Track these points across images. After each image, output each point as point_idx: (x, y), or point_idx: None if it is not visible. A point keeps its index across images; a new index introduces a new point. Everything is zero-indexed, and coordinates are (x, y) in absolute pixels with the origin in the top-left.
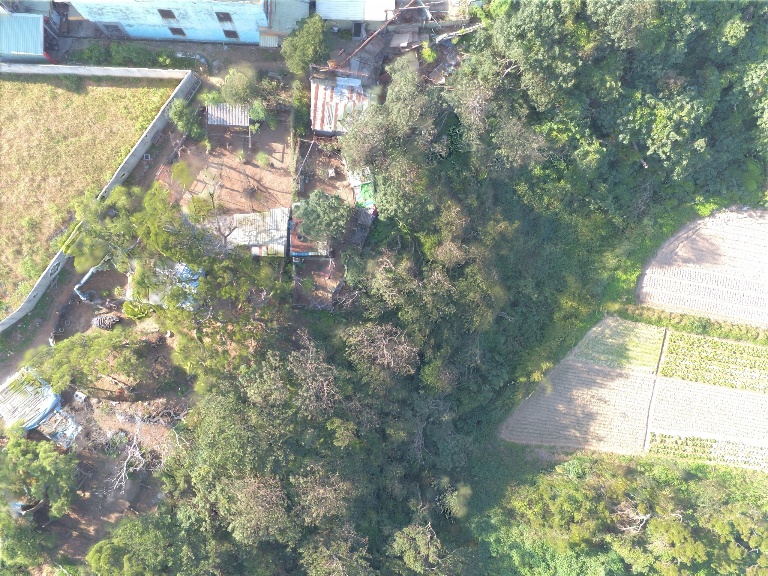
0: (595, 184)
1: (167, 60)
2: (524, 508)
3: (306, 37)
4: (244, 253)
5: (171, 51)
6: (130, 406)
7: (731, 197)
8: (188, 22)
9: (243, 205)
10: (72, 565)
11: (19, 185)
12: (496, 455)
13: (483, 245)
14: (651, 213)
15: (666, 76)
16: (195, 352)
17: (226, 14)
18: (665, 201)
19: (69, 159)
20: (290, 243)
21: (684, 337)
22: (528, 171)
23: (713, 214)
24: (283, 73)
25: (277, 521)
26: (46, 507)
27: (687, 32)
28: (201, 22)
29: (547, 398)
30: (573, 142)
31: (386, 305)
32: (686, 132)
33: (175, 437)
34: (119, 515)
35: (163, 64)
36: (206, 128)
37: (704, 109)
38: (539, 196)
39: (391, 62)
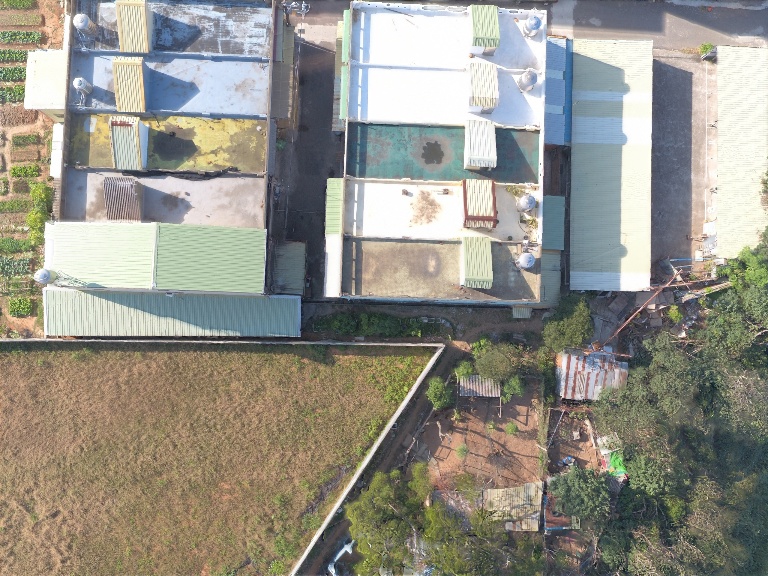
0: None
1: (420, 333)
2: None
3: (575, 325)
4: (499, 530)
5: (416, 316)
6: None
7: None
8: None
9: (488, 470)
10: None
11: (269, 460)
12: None
13: (726, 504)
14: None
15: None
16: None
17: None
18: None
19: (319, 433)
20: (544, 518)
21: None
22: None
23: None
24: None
25: None
26: None
27: None
28: (460, 301)
29: None
30: None
31: None
32: None
33: None
34: None
35: (413, 335)
36: (457, 400)
37: None
38: None
39: None
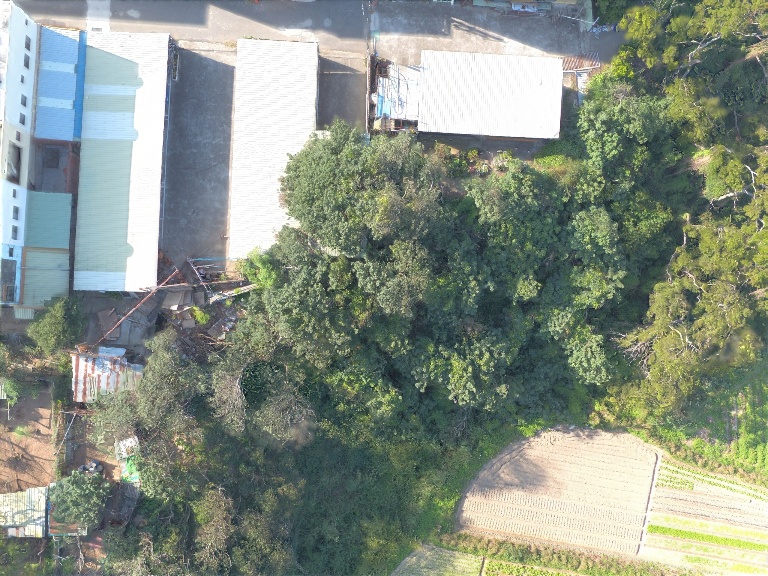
0: (406, 414)
1: None
2: None
3: (49, 326)
4: None
5: None
6: None
7: (556, 418)
8: None
9: (7, 475)
10: None
11: None
12: None
13: (262, 510)
14: (472, 435)
15: (464, 322)
16: None
17: None
18: (486, 423)
19: None
20: (48, 524)
21: (502, 566)
22: (331, 406)
23: (538, 434)
24: None
25: None
26: None
27: (472, 294)
28: None
29: None
30: (368, 390)
31: None
32: (486, 379)
33: None
34: None
35: None
36: None
37: (510, 350)
38: (346, 428)
39: (168, 318)
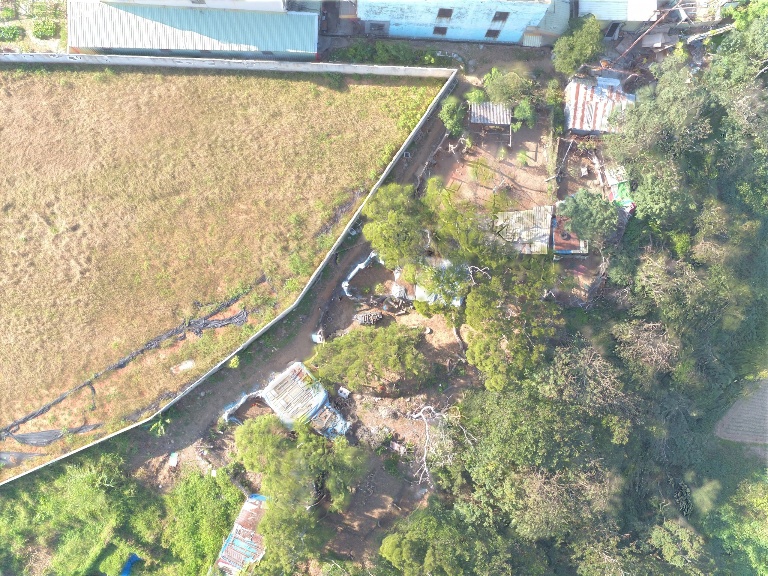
0: None
1: (432, 59)
2: (764, 505)
3: (584, 37)
4: None
5: None
6: (392, 402)
7: None
8: (459, 21)
9: (498, 203)
10: (340, 560)
11: (285, 182)
12: (716, 453)
13: (730, 244)
14: None
15: None
16: (454, 349)
17: (505, 13)
18: None
19: (334, 156)
20: (553, 241)
21: None
22: (751, 171)
23: None
24: (539, 72)
25: (557, 517)
26: (328, 502)
27: None
28: (472, 21)
29: (761, 397)
30: None
31: (654, 303)
32: None
33: (463, 433)
34: (382, 511)
35: (426, 63)
36: (468, 126)
37: None
38: (758, 196)
39: (638, 62)
